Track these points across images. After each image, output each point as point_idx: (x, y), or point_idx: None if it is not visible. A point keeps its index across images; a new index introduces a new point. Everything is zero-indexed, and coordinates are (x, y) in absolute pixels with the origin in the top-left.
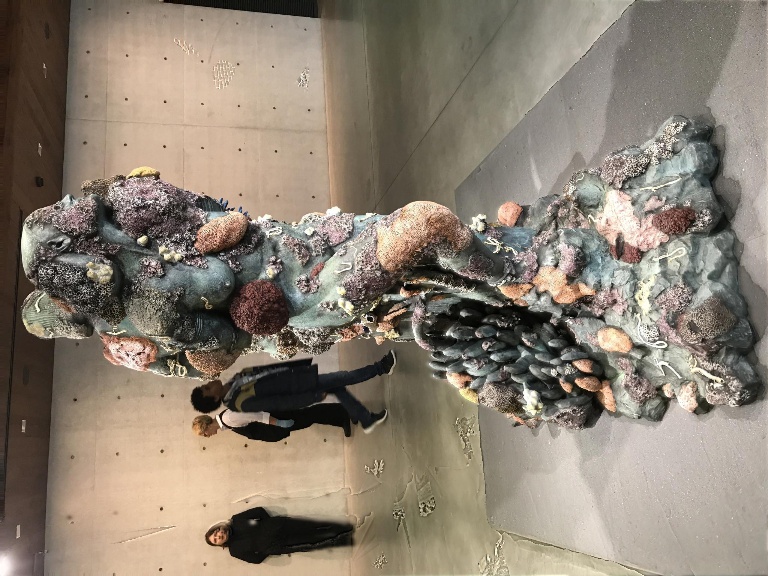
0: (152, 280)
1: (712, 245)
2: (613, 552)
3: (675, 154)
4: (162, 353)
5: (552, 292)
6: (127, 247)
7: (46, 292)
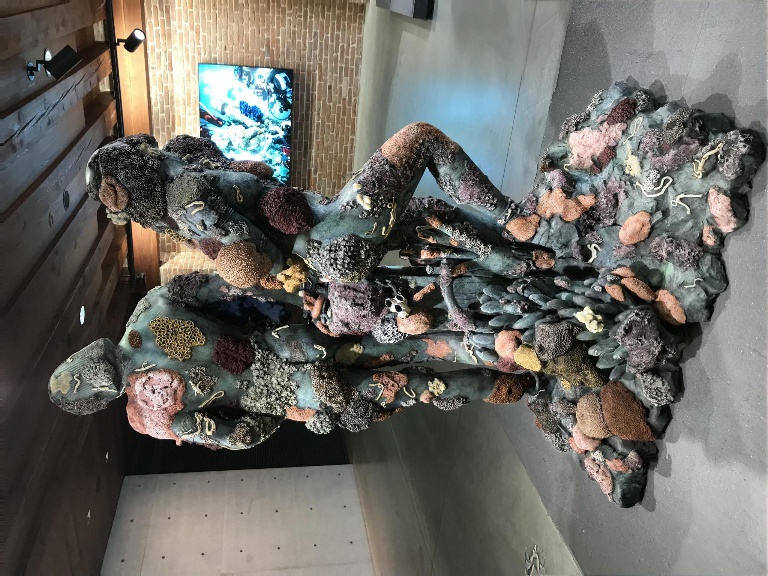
0: (192, 173)
1: (659, 108)
2: None
3: (604, 99)
4: (190, 396)
5: (557, 211)
6: (173, 158)
7: (102, 168)
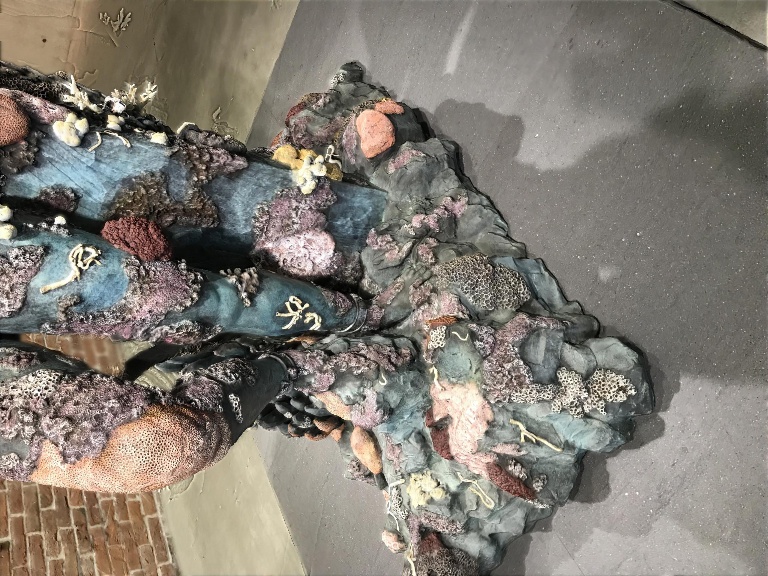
0: None
1: (523, 515)
2: (269, 467)
3: (585, 417)
4: None
5: (328, 409)
6: None
7: None
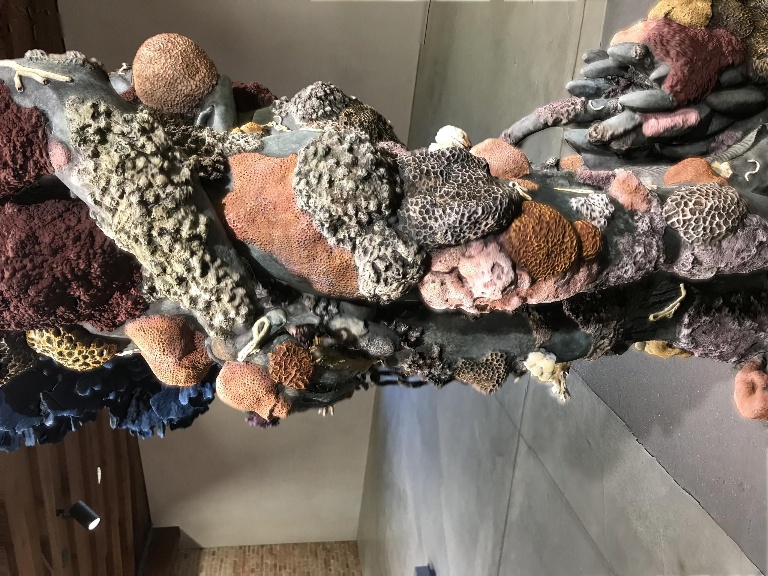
0: None
1: None
2: None
3: None
4: None
5: None
6: None
7: None
